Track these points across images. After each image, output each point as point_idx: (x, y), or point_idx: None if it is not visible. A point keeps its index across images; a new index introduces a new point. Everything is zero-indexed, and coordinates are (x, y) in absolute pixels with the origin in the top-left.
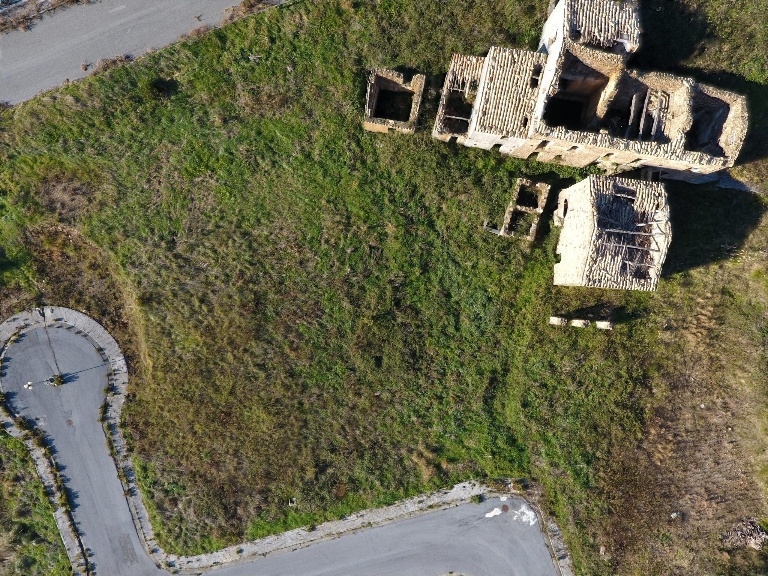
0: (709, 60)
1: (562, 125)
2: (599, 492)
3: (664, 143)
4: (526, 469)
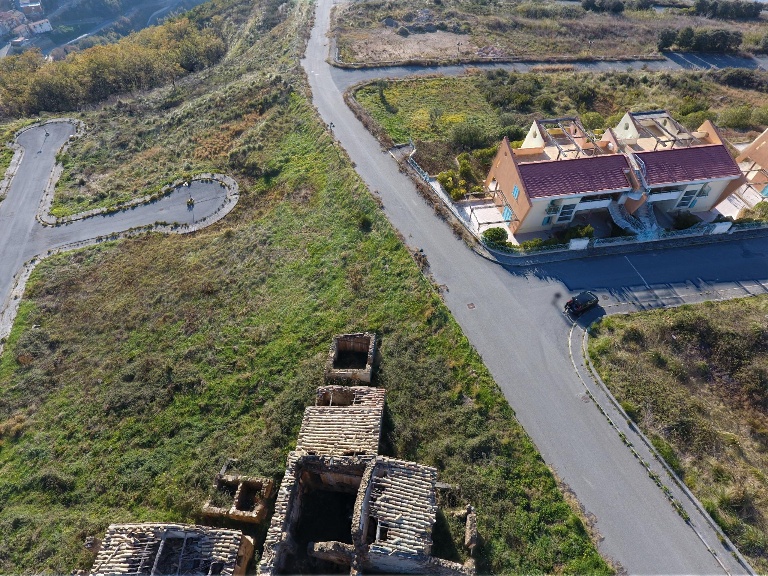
0: None
1: (325, 527)
2: None
3: None
4: None
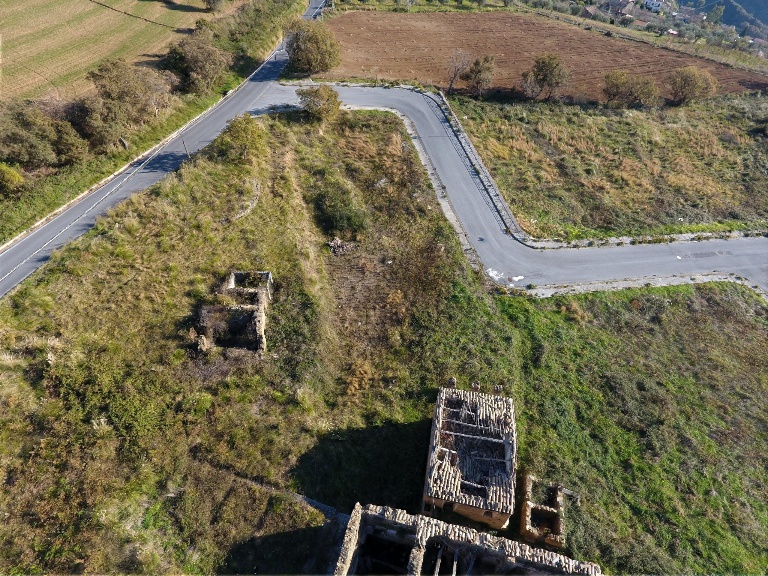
0: None
1: None
2: (446, 279)
3: None
4: (498, 300)
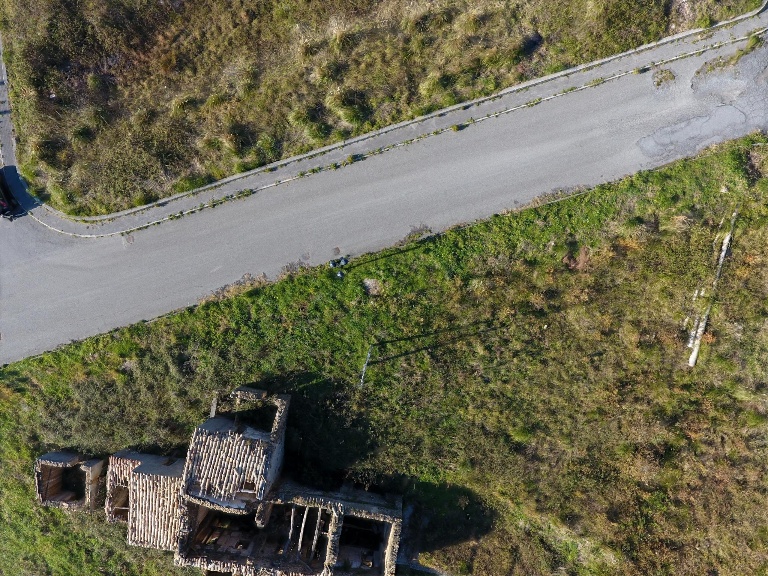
0: (379, 462)
1: None
2: None
3: (324, 559)
4: None
